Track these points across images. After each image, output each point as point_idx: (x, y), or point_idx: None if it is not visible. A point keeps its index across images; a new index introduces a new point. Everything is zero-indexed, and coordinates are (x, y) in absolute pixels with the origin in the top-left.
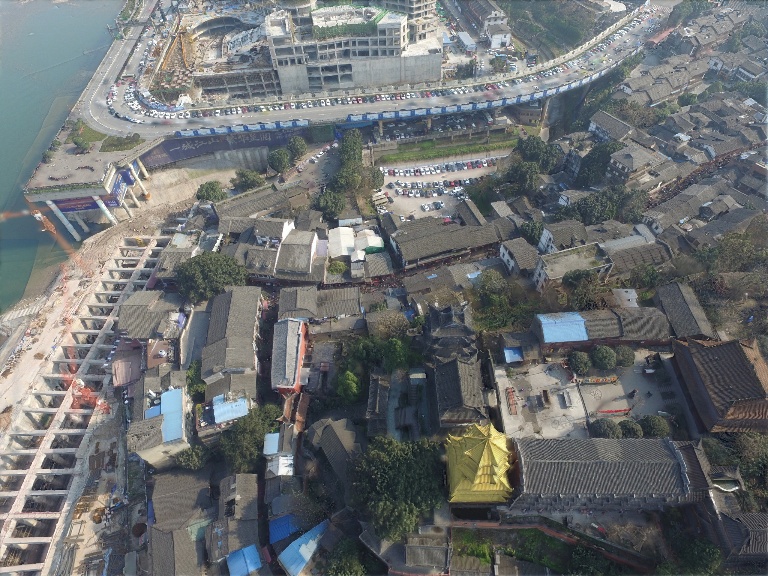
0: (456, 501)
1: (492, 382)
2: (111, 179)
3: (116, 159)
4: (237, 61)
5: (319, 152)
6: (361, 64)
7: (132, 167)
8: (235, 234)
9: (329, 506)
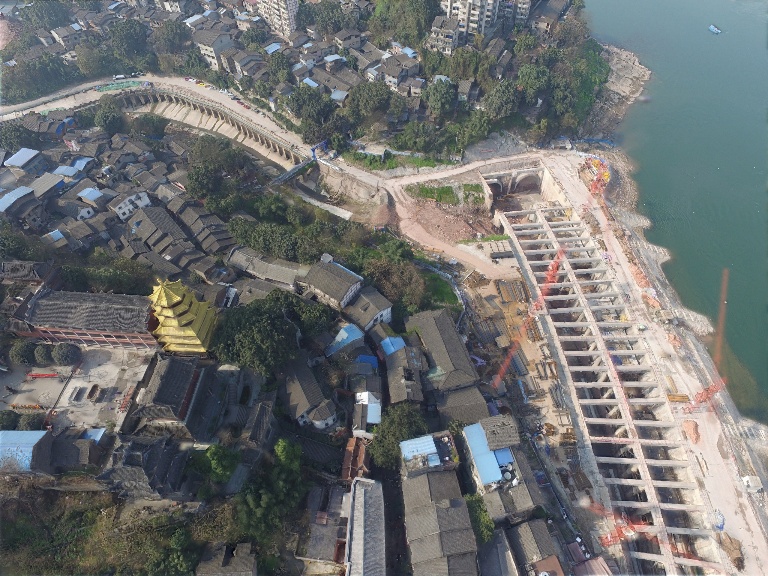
0: None
1: (134, 406)
2: None
3: None
4: None
5: None
6: None
7: None
8: None
9: (326, 368)
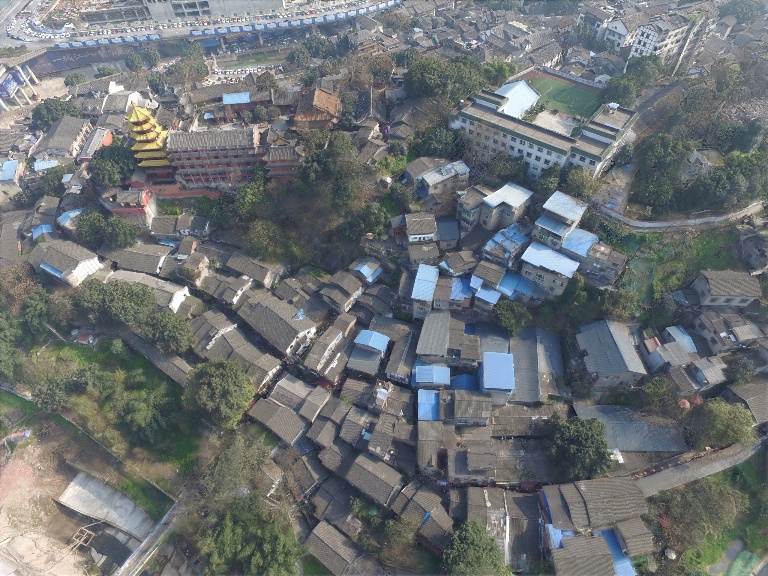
0: (144, 166)
1: None
2: (1, 75)
3: (6, 62)
4: (117, 1)
5: (172, 61)
6: (215, 1)
7: (21, 70)
8: (81, 96)
9: None
